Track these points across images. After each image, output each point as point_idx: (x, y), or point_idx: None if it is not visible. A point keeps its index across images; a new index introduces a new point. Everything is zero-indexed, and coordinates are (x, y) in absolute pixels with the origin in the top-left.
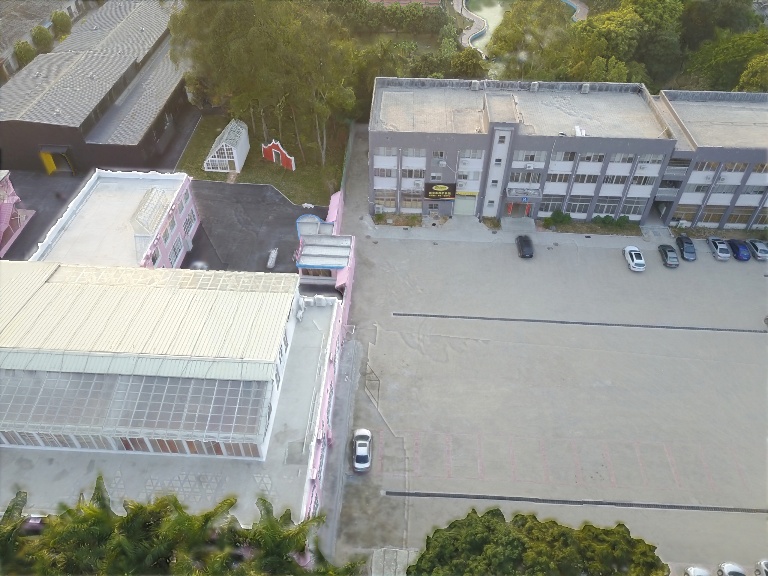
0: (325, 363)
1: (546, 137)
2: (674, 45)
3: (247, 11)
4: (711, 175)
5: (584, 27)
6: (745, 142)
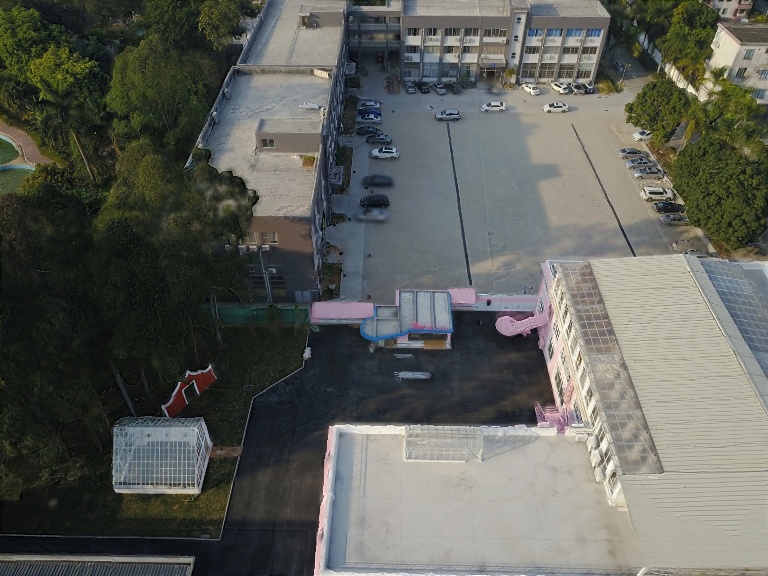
0: None
1: None
2: None
3: None
4: (338, 82)
5: (74, 78)
6: (318, 53)
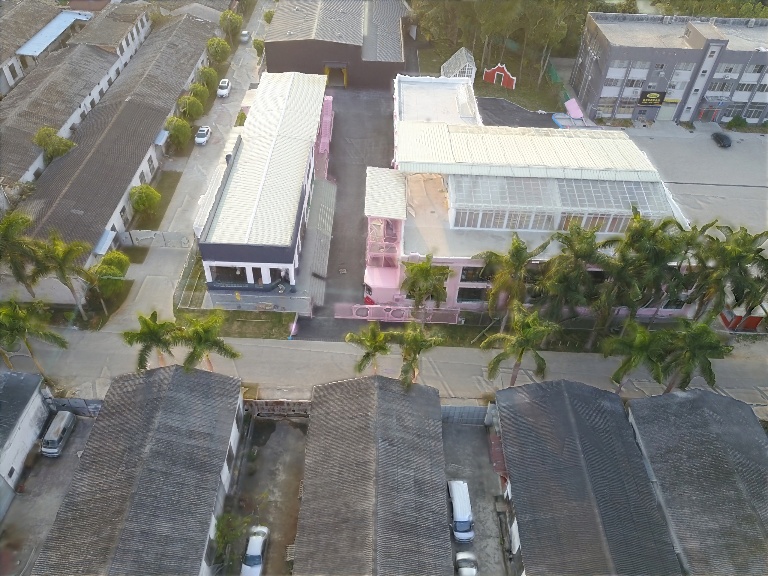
0: None
1: (746, 52)
2: None
3: None
4: None
5: None
6: None
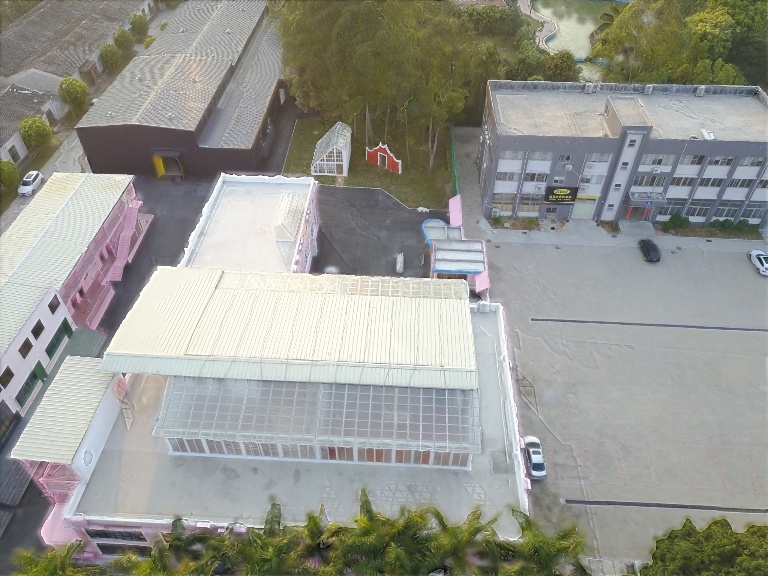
0: (507, 370)
1: (678, 141)
2: (767, 47)
3: (374, 14)
4: None
5: None
6: None
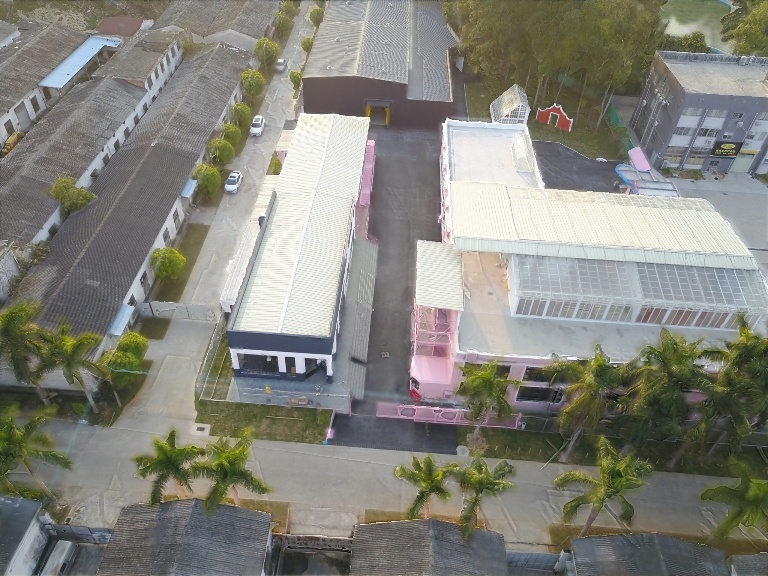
0: None
1: None
2: None
3: None
4: None
5: None
6: None
